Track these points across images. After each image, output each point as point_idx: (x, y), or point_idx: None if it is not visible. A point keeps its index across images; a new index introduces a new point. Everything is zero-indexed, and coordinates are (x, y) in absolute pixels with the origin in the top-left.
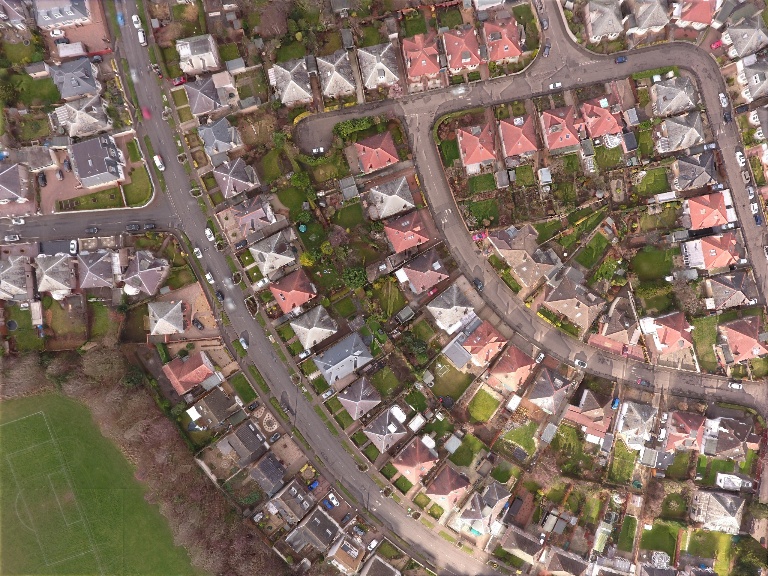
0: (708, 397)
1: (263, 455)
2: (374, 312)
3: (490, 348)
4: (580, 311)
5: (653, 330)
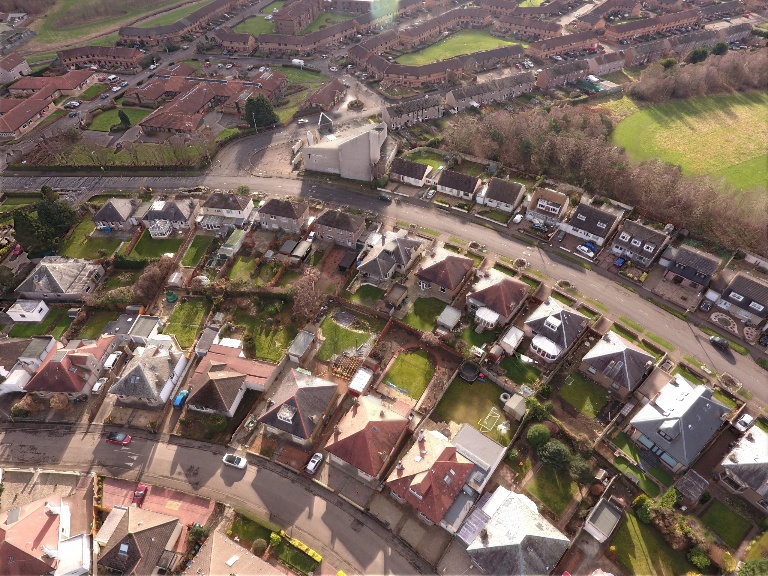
0: (3, 427)
1: (709, 284)
2: (672, 515)
3: (421, 463)
4: (229, 570)
5: (66, 546)
